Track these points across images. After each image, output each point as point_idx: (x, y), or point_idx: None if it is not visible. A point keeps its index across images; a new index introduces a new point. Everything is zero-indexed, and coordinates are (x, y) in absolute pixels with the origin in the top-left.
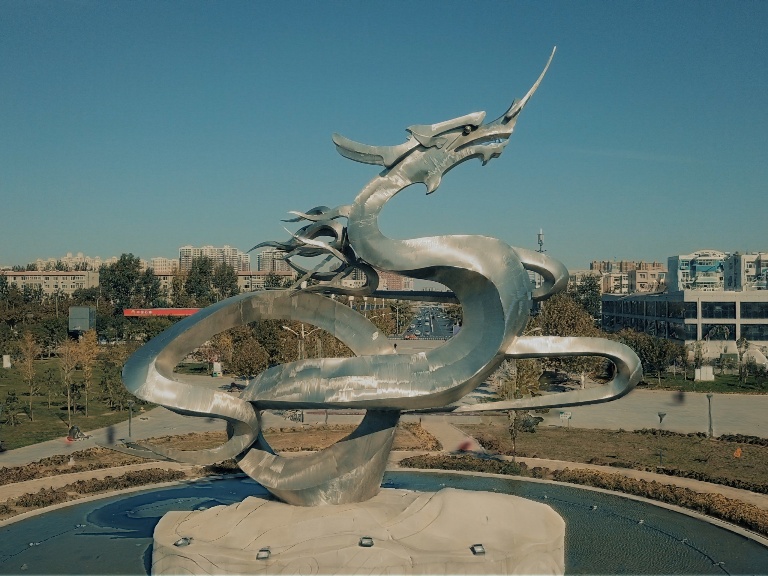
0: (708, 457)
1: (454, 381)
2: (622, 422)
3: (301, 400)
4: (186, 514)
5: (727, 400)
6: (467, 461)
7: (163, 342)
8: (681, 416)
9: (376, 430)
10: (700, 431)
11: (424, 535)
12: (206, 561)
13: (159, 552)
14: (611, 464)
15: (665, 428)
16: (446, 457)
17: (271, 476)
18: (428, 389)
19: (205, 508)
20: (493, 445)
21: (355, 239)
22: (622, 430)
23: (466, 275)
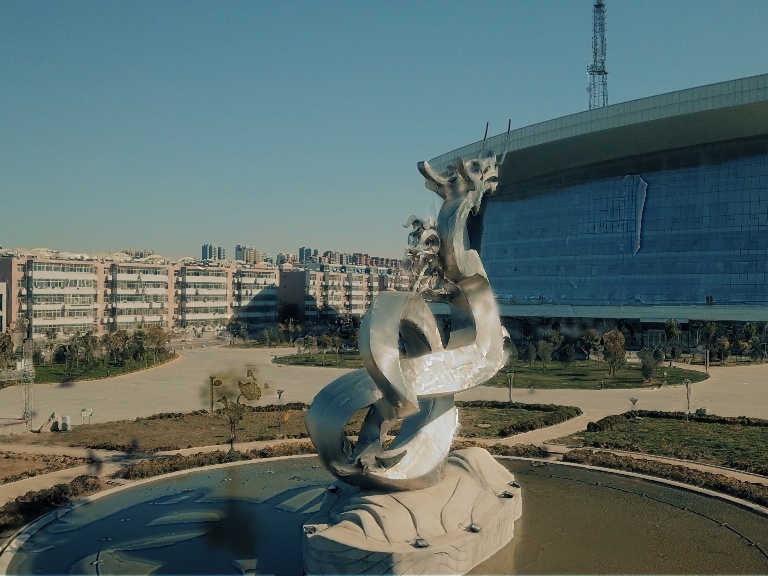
0: (281, 423)
1: (498, 363)
2: (102, 414)
3: (448, 390)
4: (346, 529)
5: (95, 387)
6: (185, 459)
7: (388, 346)
8: (120, 403)
9: (446, 411)
10: (183, 410)
11: (492, 485)
12: (454, 549)
13: (407, 561)
14: (257, 439)
15: (152, 412)
16: (163, 460)
17: (396, 469)
18: (493, 370)
19: (309, 527)
20: (125, 446)
21: (456, 249)
22: (142, 418)
23: (480, 281)
